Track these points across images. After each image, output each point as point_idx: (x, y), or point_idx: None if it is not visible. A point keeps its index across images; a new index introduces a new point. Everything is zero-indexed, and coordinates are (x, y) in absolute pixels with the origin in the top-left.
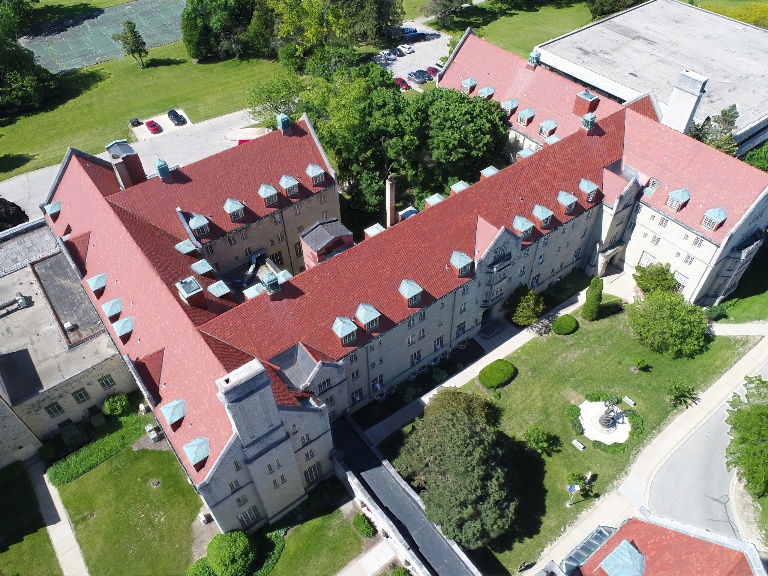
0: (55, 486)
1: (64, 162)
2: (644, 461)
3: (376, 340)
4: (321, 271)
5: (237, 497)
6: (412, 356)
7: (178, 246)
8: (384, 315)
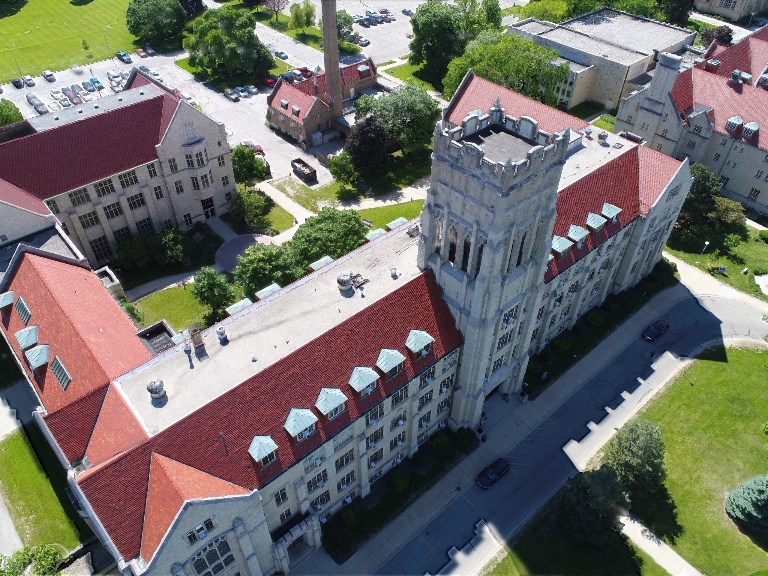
0: (600, 118)
1: (765, 26)
2: (755, 301)
3: (741, 144)
4: (761, 93)
5: (625, 128)
6: (753, 191)
7: (744, 72)
8: (759, 137)
